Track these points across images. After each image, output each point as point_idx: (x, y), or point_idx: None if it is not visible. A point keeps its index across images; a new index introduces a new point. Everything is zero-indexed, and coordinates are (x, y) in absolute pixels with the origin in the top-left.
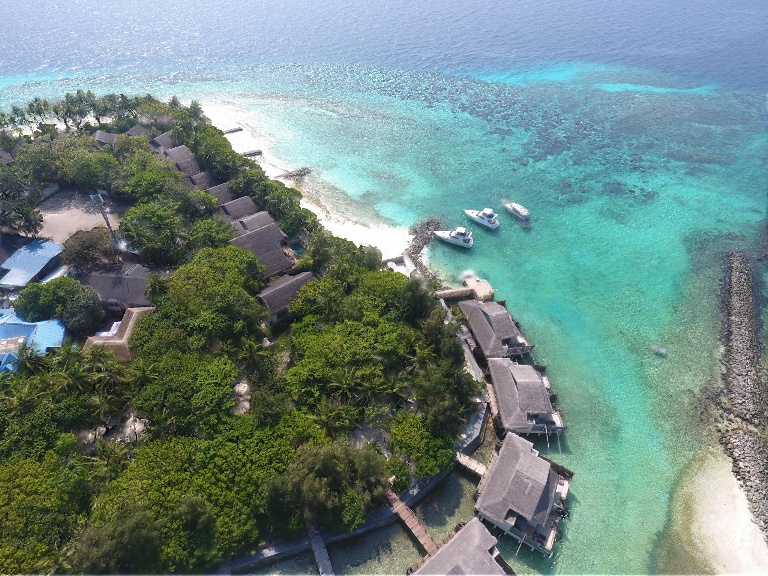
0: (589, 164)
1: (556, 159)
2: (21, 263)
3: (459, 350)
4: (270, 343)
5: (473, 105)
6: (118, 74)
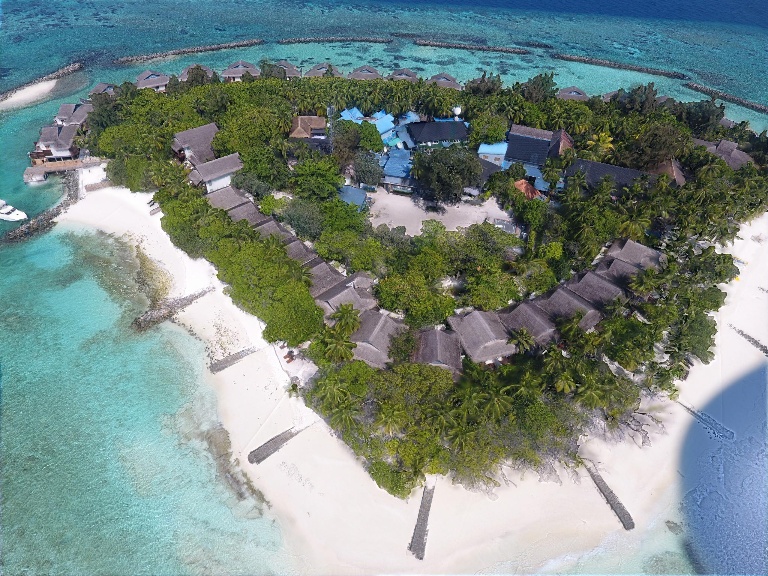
0: None
1: None
2: None
3: None
4: None
5: None
6: None
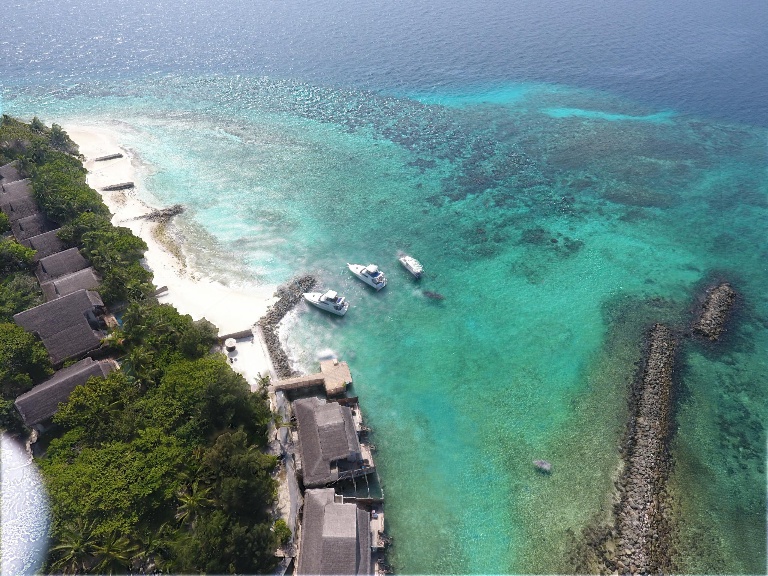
0: (513, 205)
1: (477, 198)
2: None
3: (250, 491)
4: (30, 461)
5: (399, 131)
6: (8, 85)
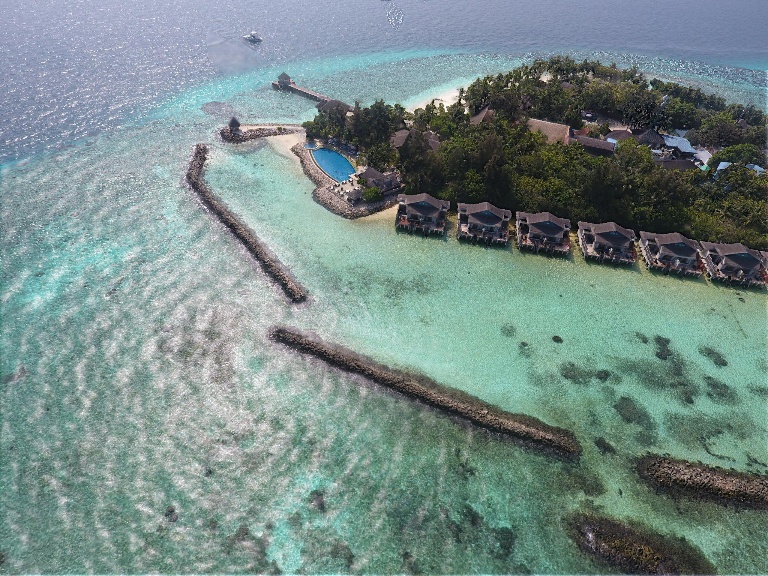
0: None
1: None
2: None
3: None
4: None
5: (762, 82)
6: None
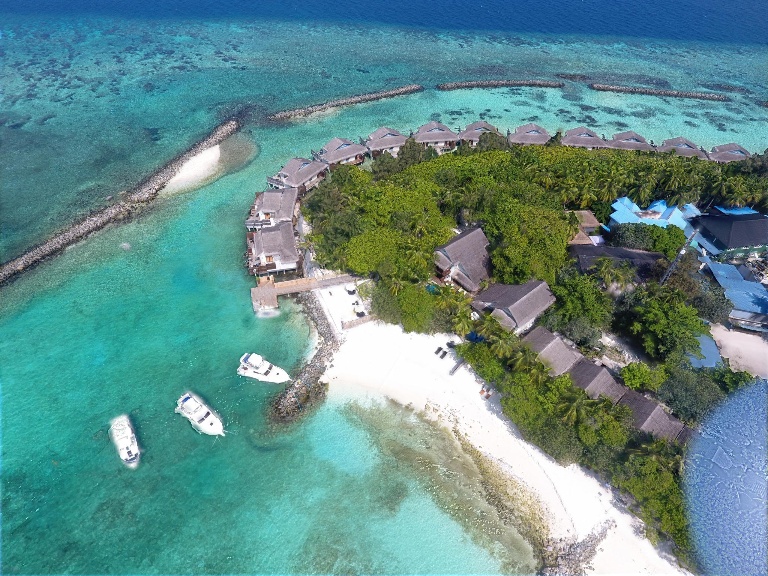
0: None
1: None
2: (746, 285)
3: None
4: None
5: None
6: None
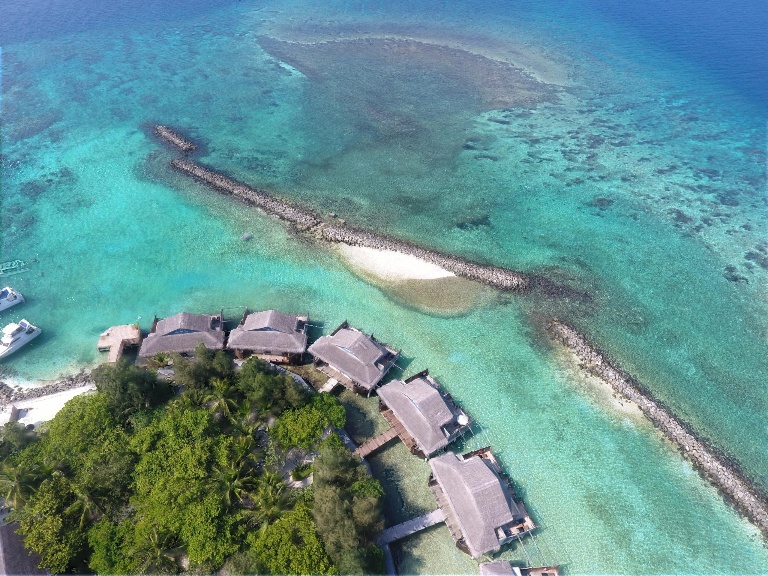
0: None
1: None
2: None
3: None
4: None
5: None
6: None
